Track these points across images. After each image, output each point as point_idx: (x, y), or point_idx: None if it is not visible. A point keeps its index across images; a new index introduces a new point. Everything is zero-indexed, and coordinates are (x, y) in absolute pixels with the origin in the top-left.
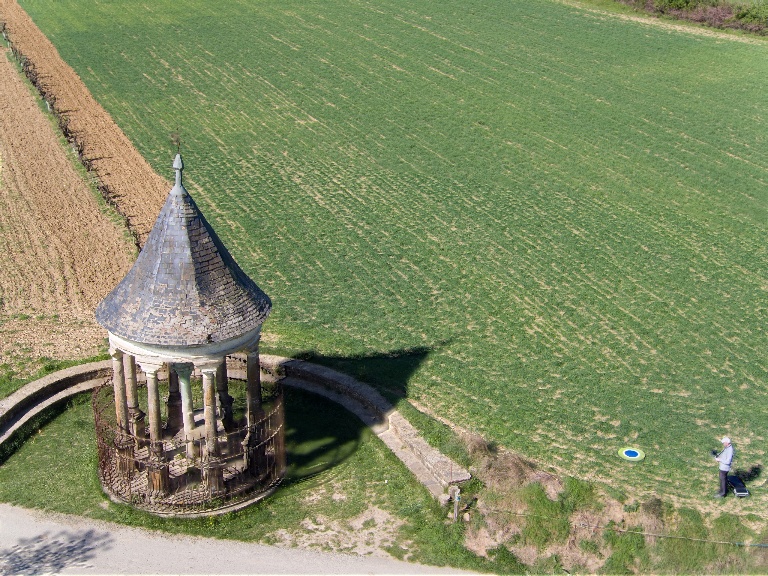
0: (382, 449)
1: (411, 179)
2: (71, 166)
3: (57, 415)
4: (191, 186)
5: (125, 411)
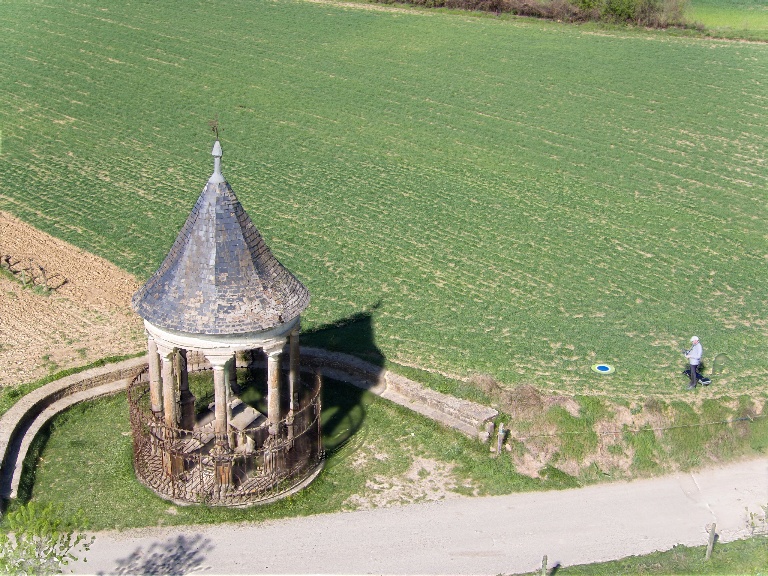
0: (393, 407)
1: None
2: None
3: (46, 440)
4: None
5: (175, 412)
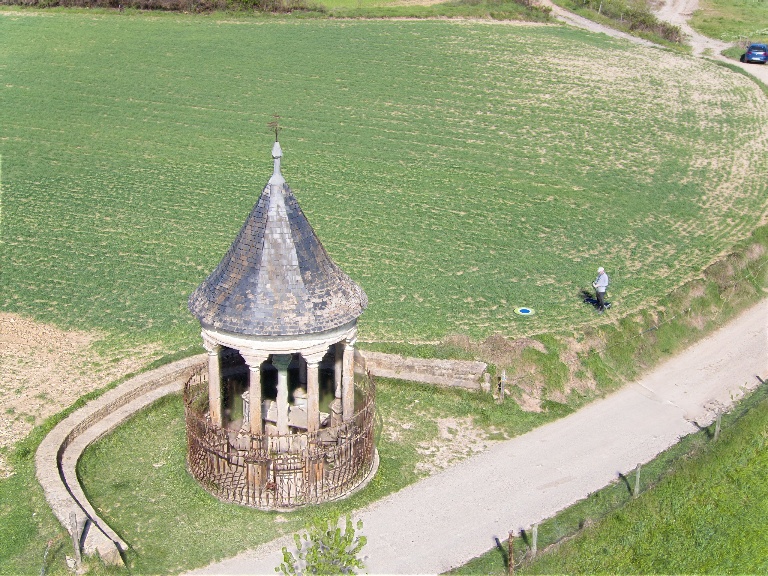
0: (384, 381)
1: None
2: None
3: None
4: None
5: (261, 422)
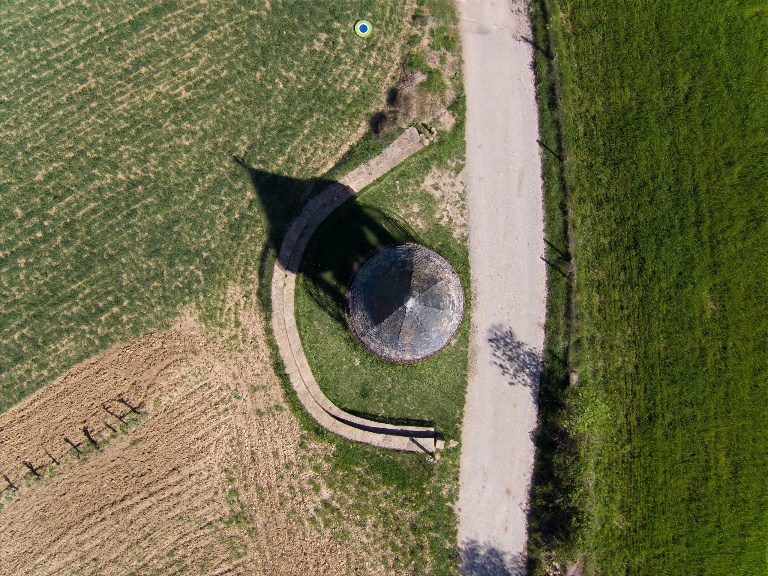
0: None
1: None
2: None
3: None
4: None
5: None
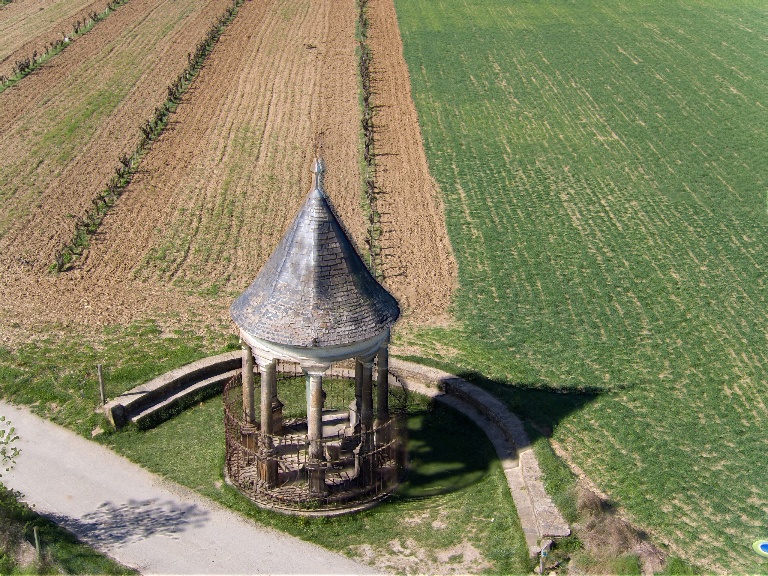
0: (502, 485)
1: (685, 209)
2: (357, 159)
3: None
4: (456, 191)
5: (250, 398)
